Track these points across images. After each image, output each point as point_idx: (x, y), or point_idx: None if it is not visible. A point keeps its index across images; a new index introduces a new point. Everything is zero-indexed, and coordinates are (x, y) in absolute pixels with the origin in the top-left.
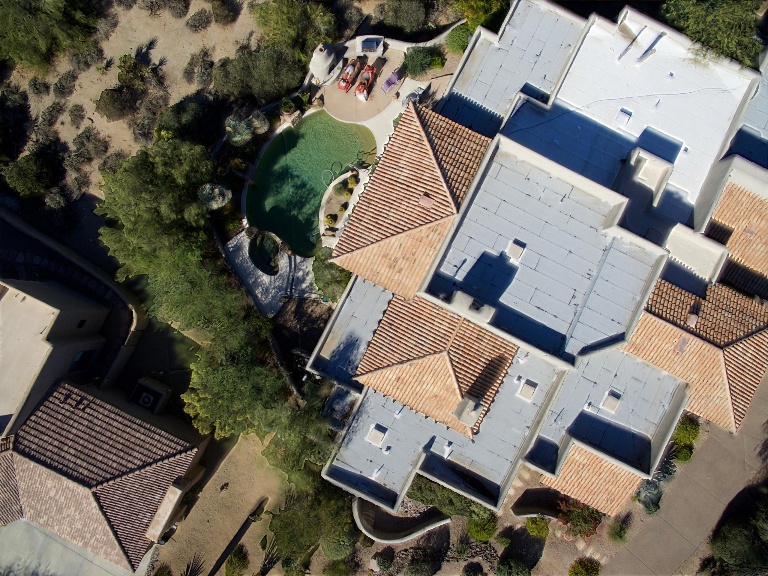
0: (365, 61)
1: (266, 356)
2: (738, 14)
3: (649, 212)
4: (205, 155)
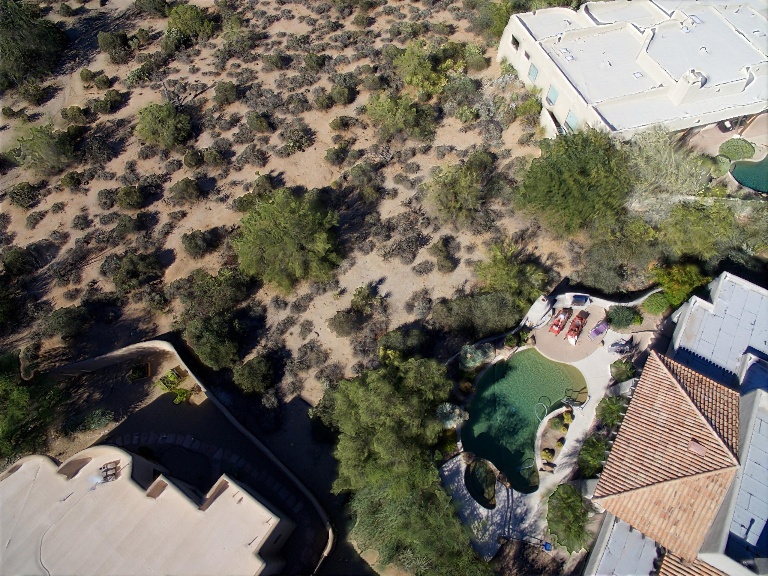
0: (570, 312)
1: None
2: None
3: None
4: (445, 376)
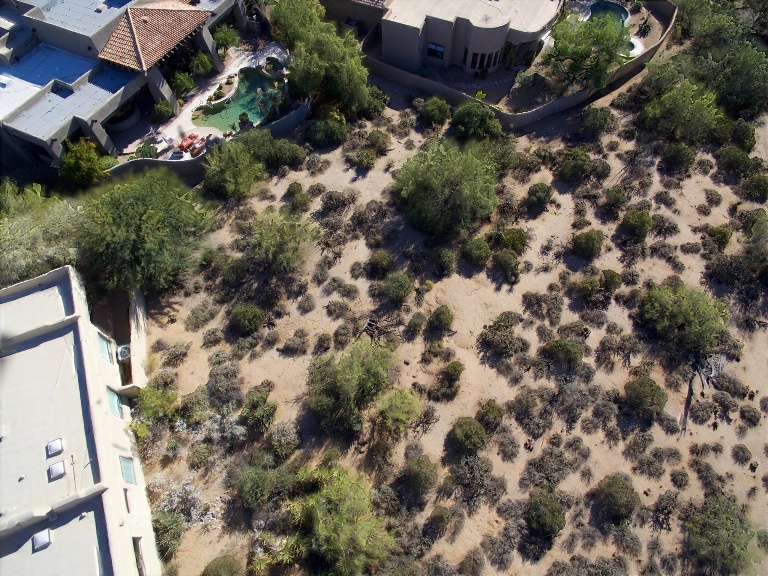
0: None
1: None
2: None
3: None
4: (294, 75)
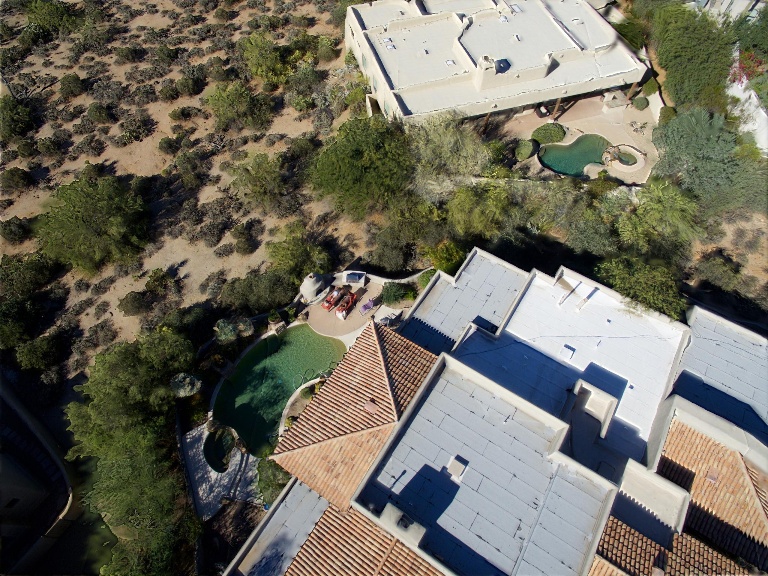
0: (349, 289)
1: (189, 570)
2: (658, 279)
3: (598, 443)
4: (189, 348)
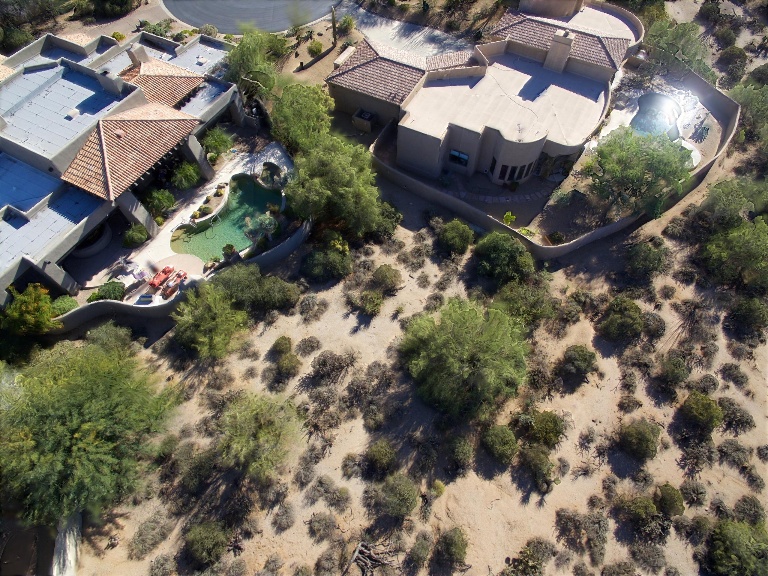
0: None
1: None
2: None
3: None
4: (290, 200)
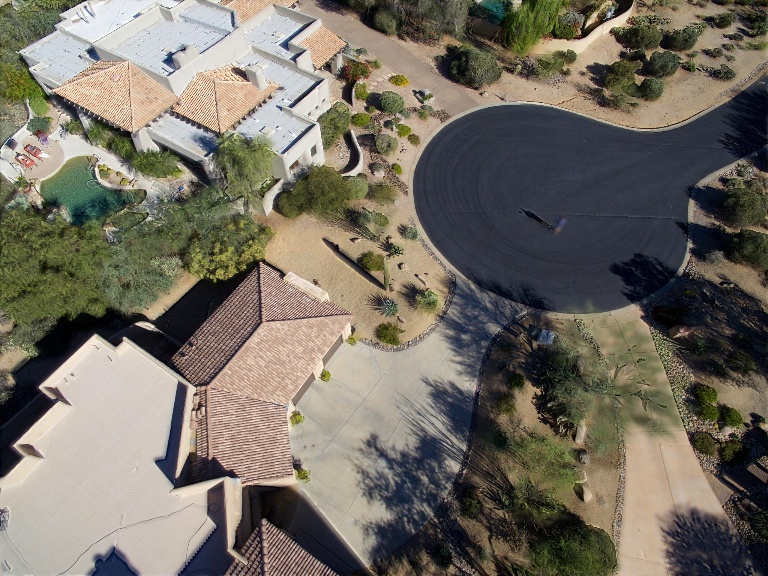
0: None
1: None
2: None
3: None
4: None
